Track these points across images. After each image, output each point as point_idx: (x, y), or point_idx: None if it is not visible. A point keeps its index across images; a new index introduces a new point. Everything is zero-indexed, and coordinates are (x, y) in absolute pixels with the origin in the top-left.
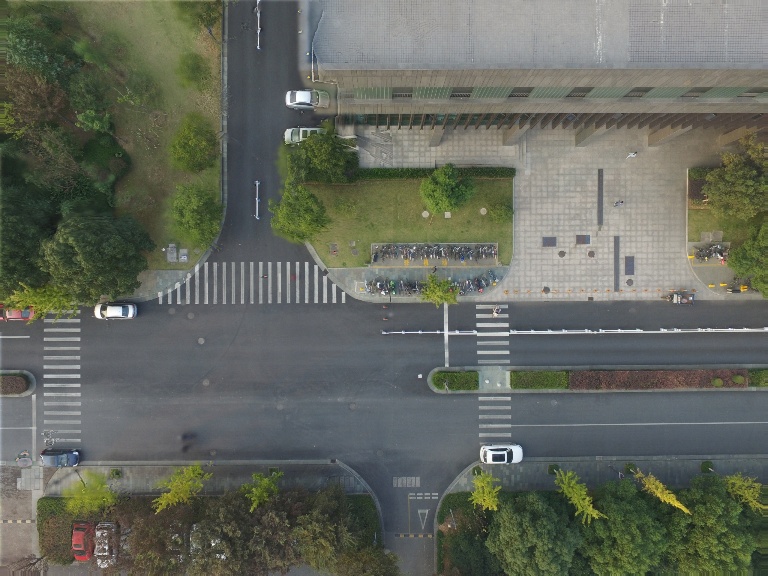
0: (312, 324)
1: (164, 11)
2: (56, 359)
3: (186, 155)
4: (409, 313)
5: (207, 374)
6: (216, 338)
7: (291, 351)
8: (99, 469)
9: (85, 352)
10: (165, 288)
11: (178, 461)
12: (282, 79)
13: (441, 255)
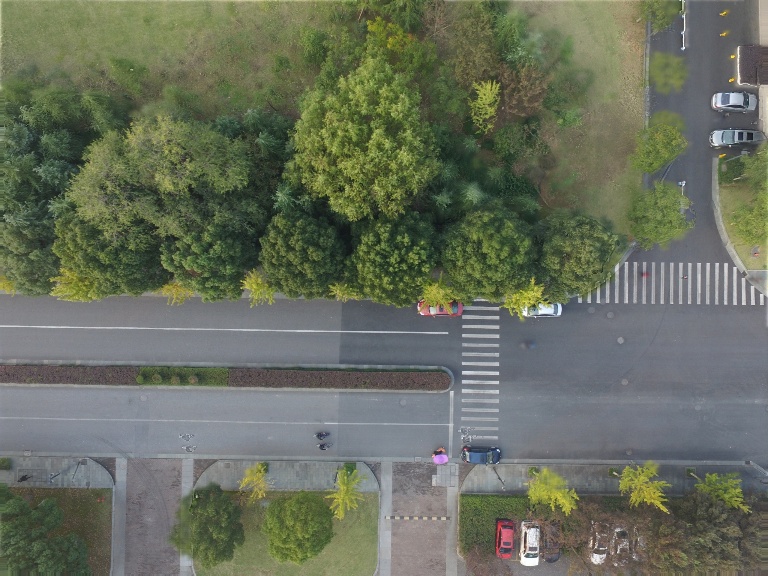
0: (732, 325)
1: (587, 10)
2: (476, 356)
3: (666, 155)
4: None
5: (626, 373)
6: (636, 338)
7: (710, 352)
8: (516, 467)
9: (504, 349)
10: (585, 287)
11: (594, 460)
12: (704, 81)
13: None
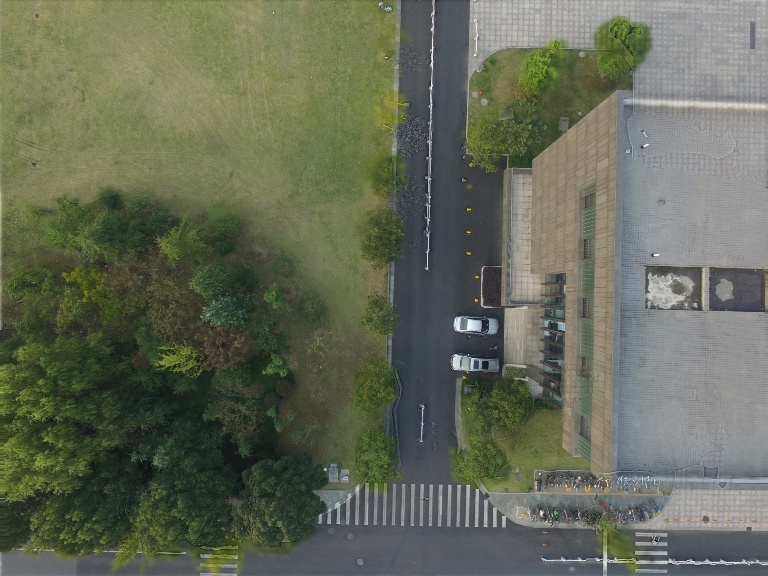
0: (472, 548)
1: (331, 227)
2: None
3: (373, 406)
4: (569, 539)
5: None
6: (375, 559)
7: (450, 575)
8: None
9: (242, 570)
10: (325, 508)
11: None
12: (449, 300)
13: (605, 485)
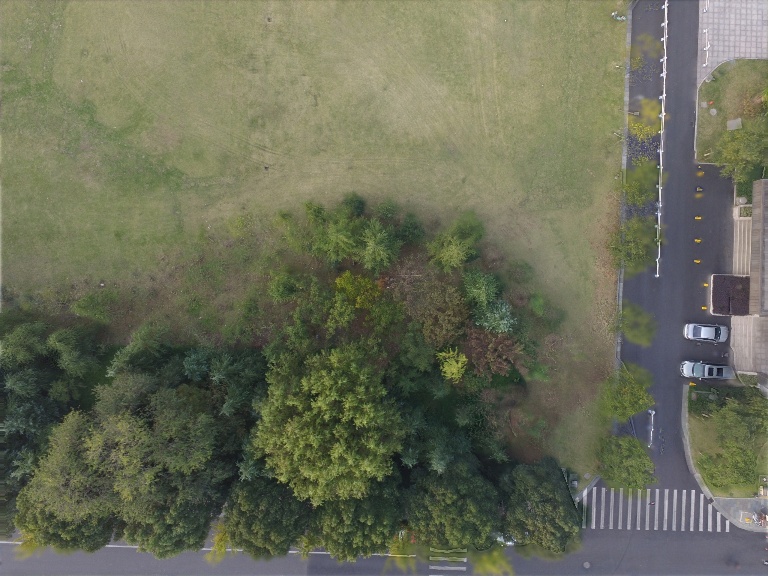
0: (697, 552)
1: (562, 234)
2: None
3: None
4: None
5: None
6: (602, 563)
7: None
8: None
9: (471, 572)
10: None
11: None
12: (677, 307)
13: None
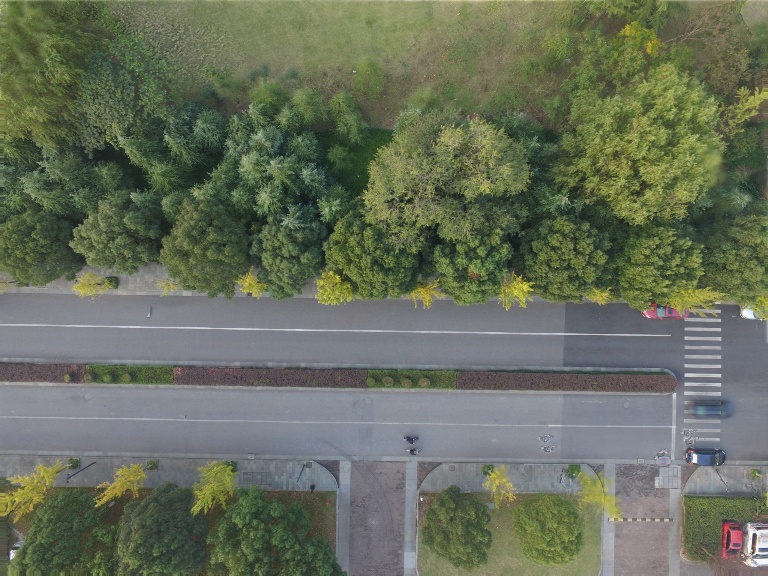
0: None
1: None
2: (700, 358)
3: None
4: None
5: None
6: None
7: None
8: (739, 468)
9: (727, 352)
10: None
11: None
12: None
13: None
